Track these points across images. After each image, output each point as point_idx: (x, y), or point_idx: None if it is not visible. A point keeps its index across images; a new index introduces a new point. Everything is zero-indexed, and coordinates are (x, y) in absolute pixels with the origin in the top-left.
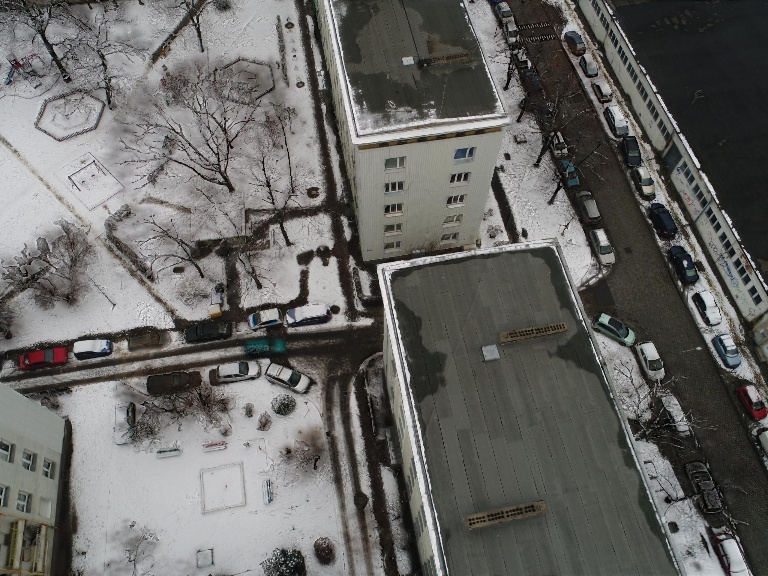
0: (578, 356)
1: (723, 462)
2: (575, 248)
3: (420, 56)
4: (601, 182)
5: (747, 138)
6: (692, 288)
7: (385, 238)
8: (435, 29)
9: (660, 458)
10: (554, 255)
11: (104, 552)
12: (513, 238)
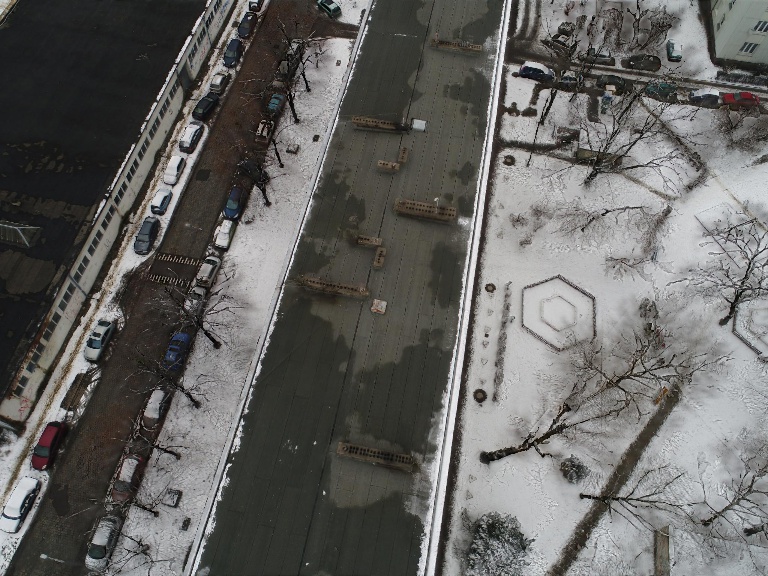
0: None
1: None
2: None
3: None
4: None
5: (130, 40)
6: None
7: None
8: (411, 1)
9: None
10: None
11: (680, 4)
12: None
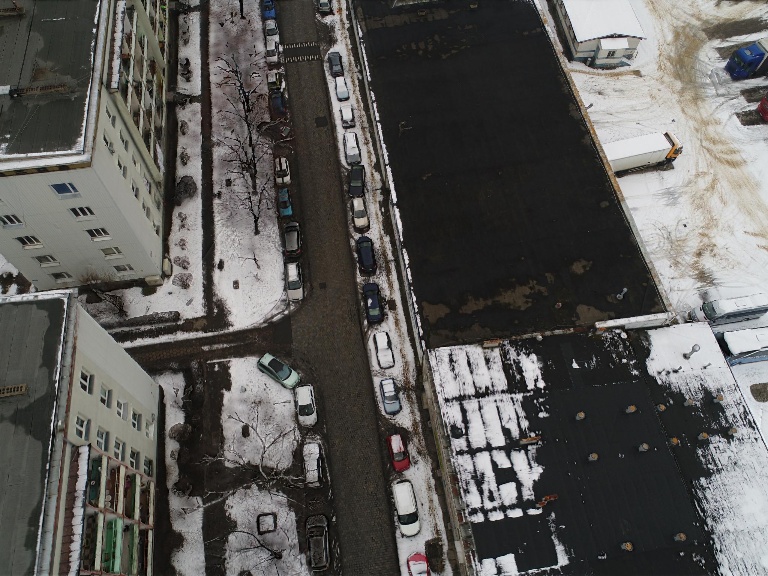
0: (32, 421)
1: (351, 515)
2: (268, 282)
3: (20, 85)
4: (318, 212)
5: (453, 173)
6: (377, 328)
7: (44, 269)
8: (51, 56)
9: (286, 510)
10: (61, 308)
11: None
12: (207, 269)
